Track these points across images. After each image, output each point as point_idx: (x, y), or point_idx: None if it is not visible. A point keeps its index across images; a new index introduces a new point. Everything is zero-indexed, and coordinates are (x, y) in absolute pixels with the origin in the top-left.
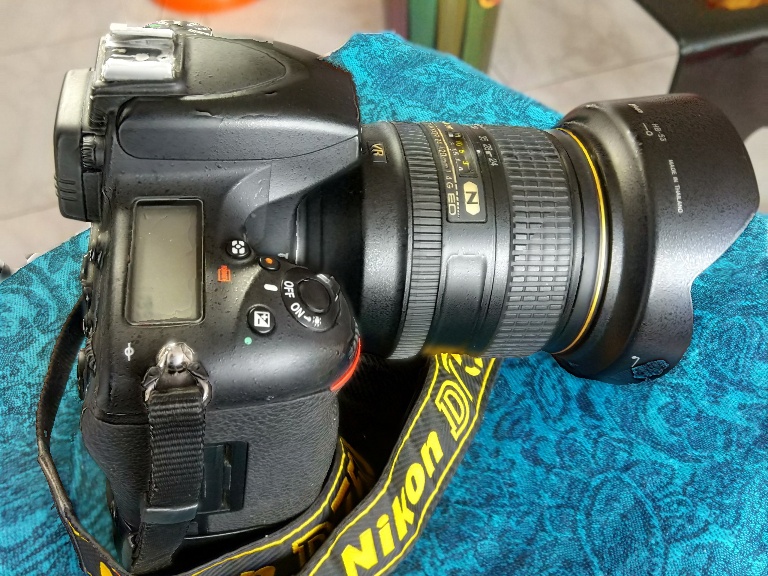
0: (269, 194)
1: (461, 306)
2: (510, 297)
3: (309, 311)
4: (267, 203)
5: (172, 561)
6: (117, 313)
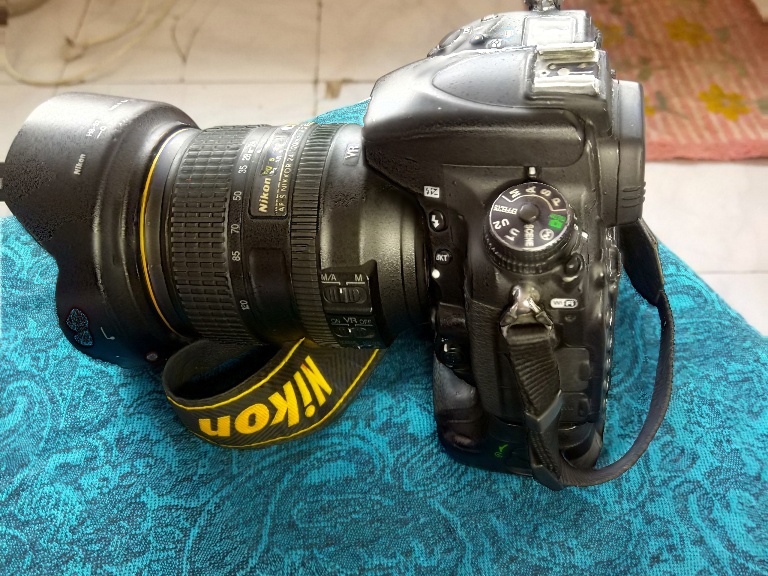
0: None
1: None
2: None
3: None
4: None
5: None
6: (580, 20)
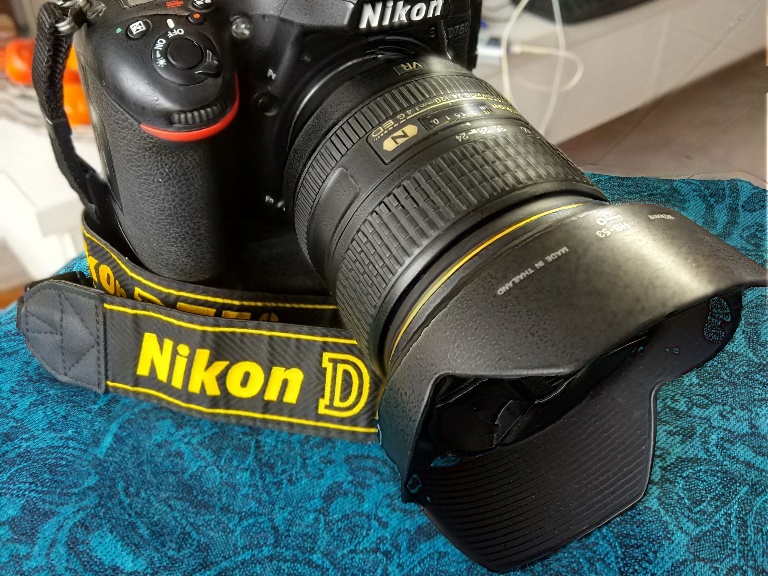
0: (283, 10)
1: (325, 225)
2: (350, 250)
3: (165, 53)
4: (279, 17)
5: (102, 224)
6: None
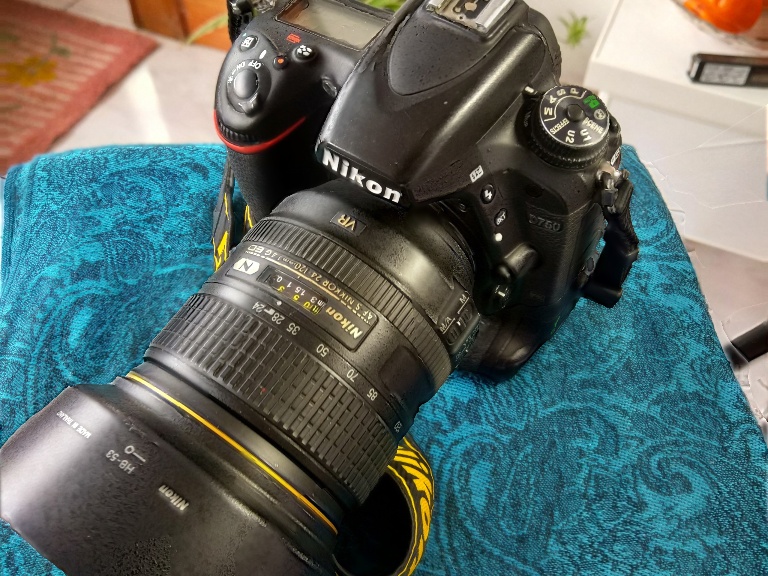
0: None
1: None
2: None
3: None
4: None
5: None
6: None
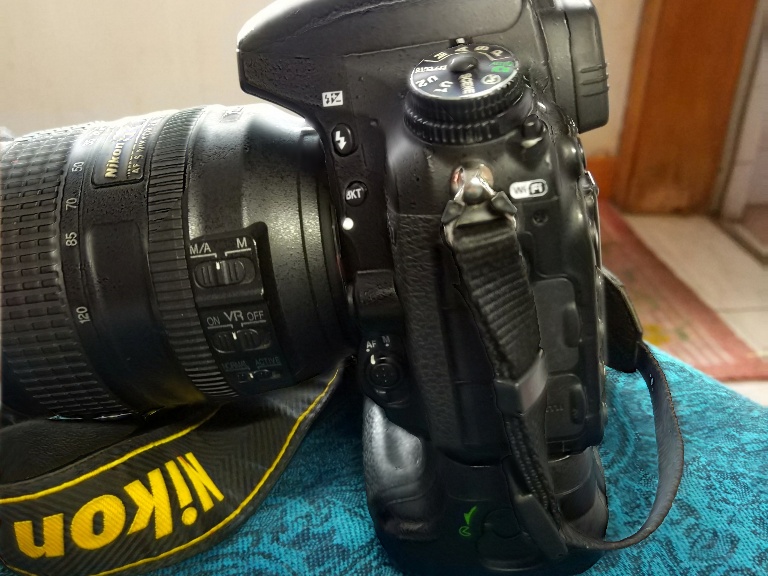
0: None
1: None
2: None
3: None
4: None
5: None
6: None
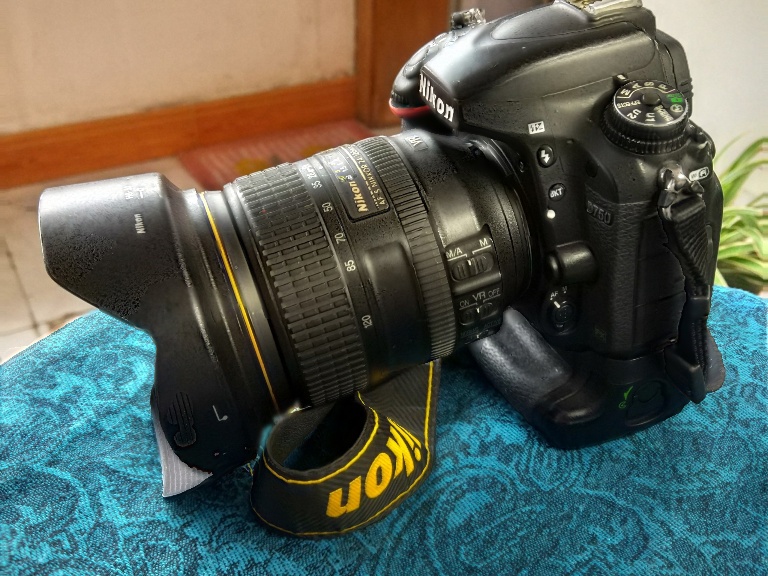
0: None
1: None
2: None
3: None
4: None
5: None
6: None
